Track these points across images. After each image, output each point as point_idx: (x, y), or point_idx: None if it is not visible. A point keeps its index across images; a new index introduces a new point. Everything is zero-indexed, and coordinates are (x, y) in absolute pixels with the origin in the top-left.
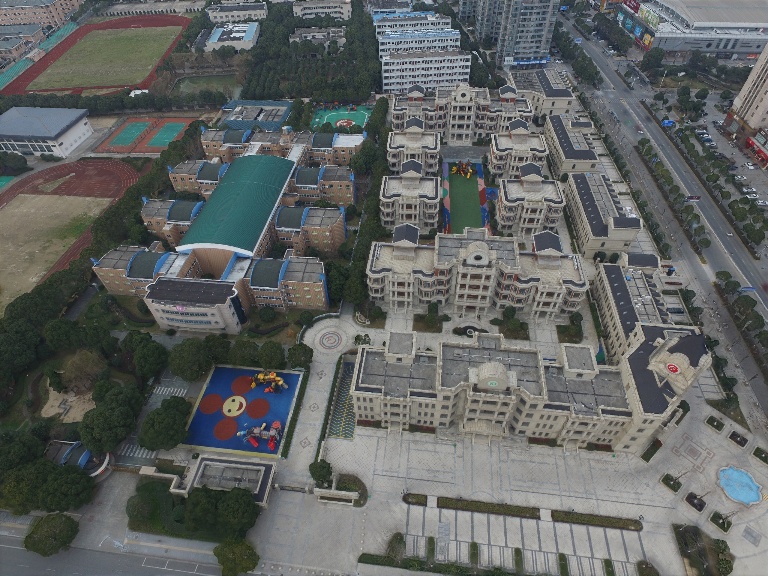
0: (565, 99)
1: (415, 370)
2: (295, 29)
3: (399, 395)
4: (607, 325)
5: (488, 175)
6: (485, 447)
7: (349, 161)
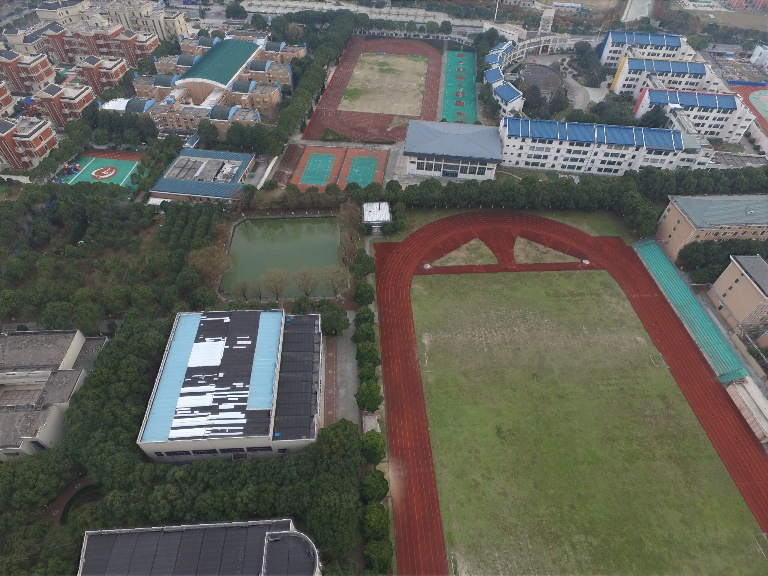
0: None
1: None
2: (42, 428)
3: None
4: None
5: None
6: None
7: None
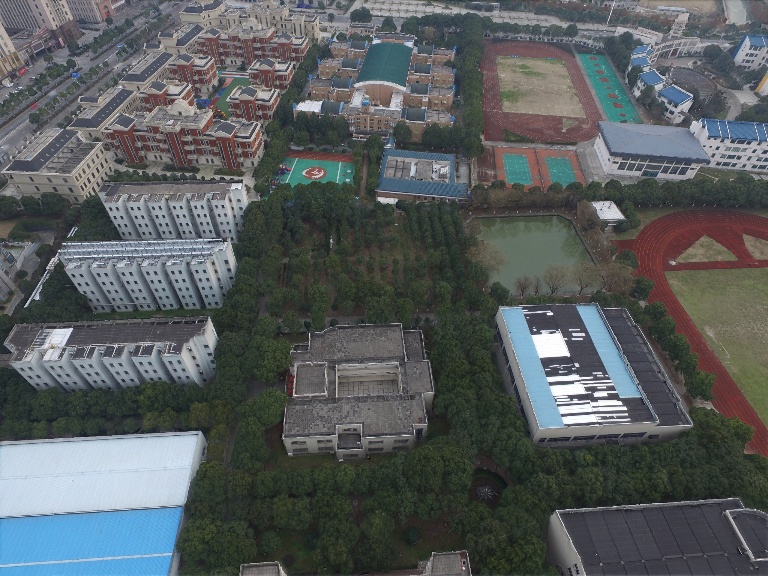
0: None
1: None
2: None
3: None
4: None
5: None
6: None
7: None
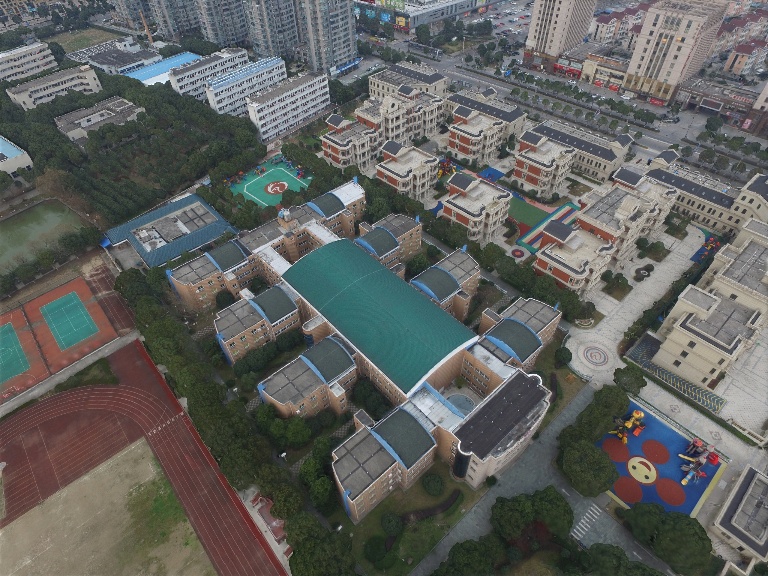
0: (442, 81)
1: (722, 310)
2: (55, 120)
3: (747, 332)
4: (687, 211)
5: (467, 164)
6: (766, 330)
7: (360, 214)
